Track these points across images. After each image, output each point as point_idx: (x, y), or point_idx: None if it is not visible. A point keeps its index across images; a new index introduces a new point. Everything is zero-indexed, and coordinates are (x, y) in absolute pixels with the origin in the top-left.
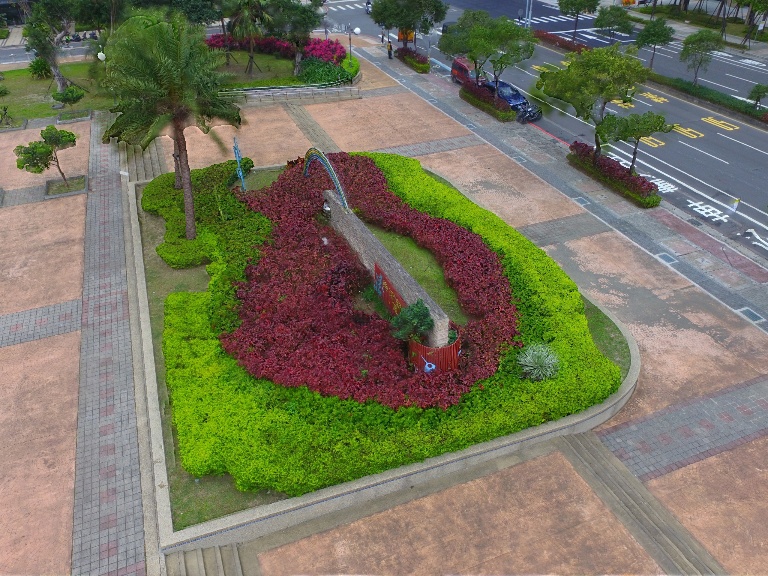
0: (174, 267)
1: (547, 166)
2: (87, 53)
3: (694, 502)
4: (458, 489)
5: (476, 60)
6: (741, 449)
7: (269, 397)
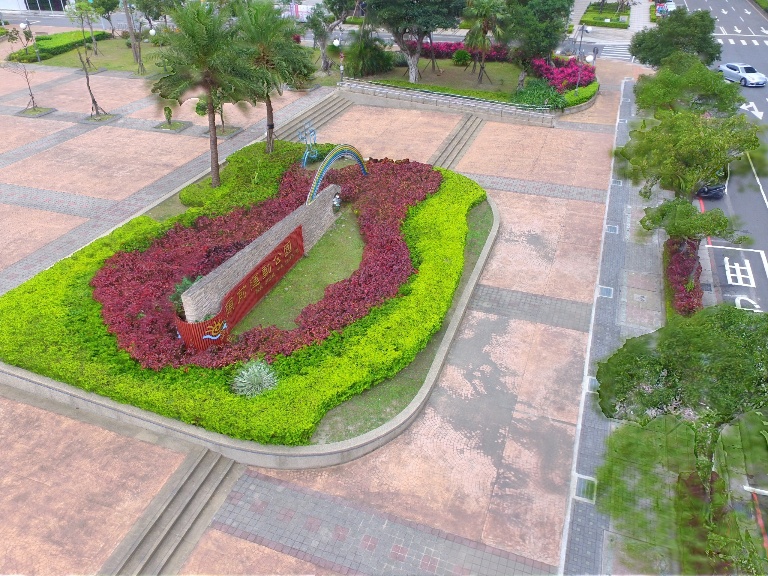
0: (181, 202)
1: (631, 245)
2: (347, 40)
3: (215, 571)
4: (94, 429)
5: (677, 112)
6: (328, 574)
7: (78, 299)
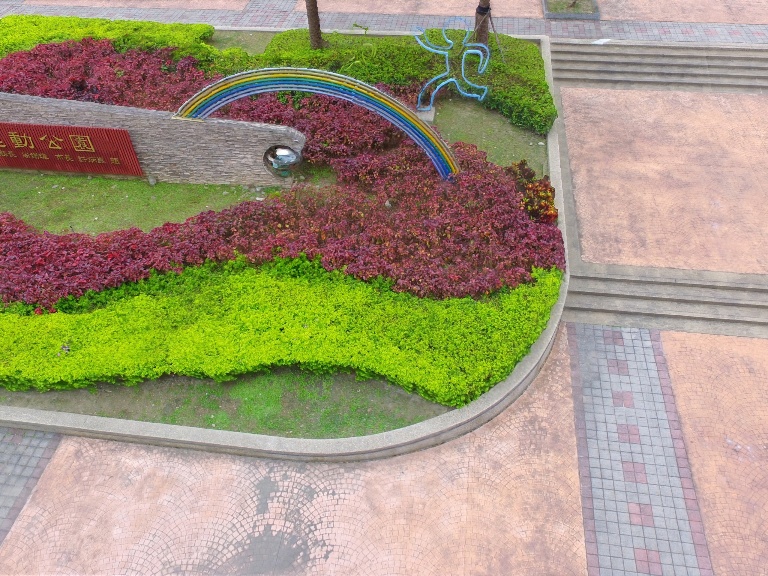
0: None
1: None
2: None
3: None
4: None
5: None
6: None
7: None
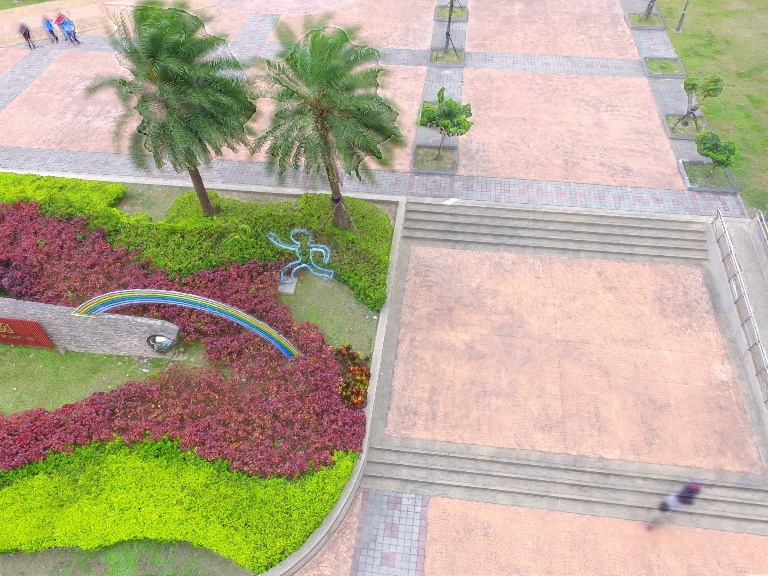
0: None
1: None
2: None
3: None
4: None
5: None
6: None
7: None
